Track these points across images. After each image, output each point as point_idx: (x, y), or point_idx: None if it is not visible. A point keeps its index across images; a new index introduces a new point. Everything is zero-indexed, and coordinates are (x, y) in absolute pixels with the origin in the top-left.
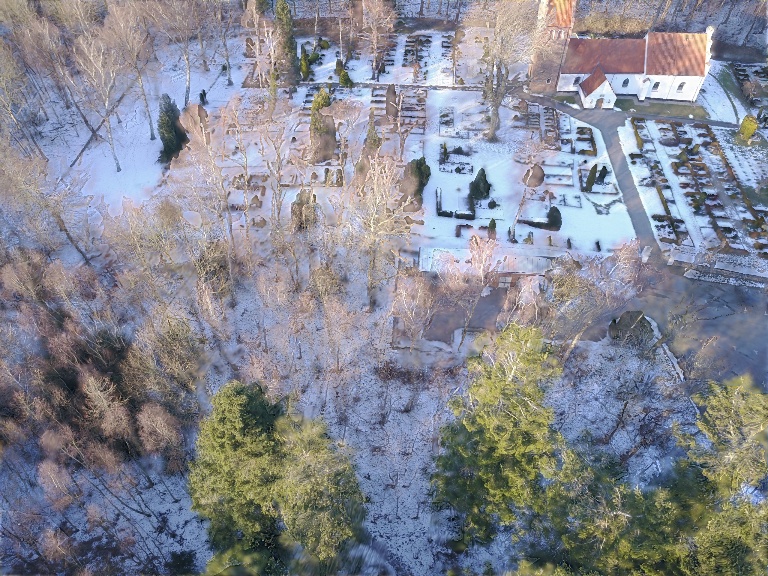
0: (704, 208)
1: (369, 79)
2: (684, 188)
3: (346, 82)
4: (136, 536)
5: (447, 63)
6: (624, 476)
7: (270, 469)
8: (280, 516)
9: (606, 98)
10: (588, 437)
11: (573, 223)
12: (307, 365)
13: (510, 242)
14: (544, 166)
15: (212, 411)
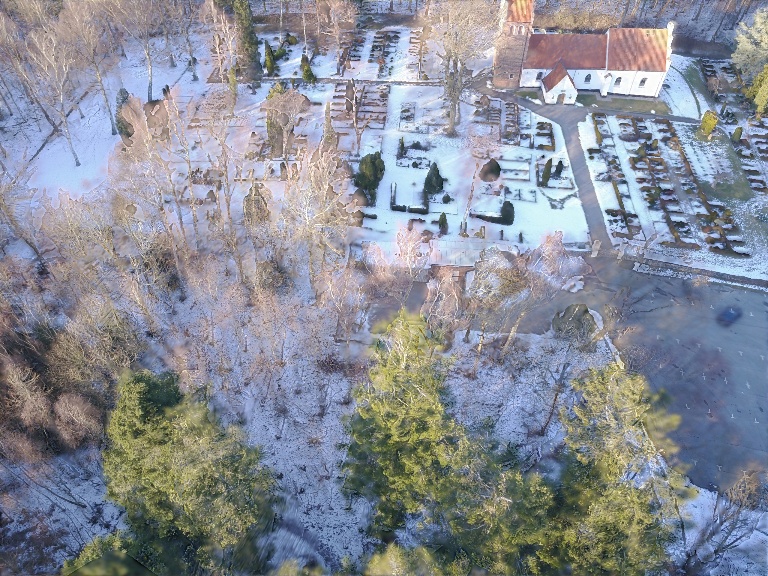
0: (659, 203)
1: (334, 74)
2: (640, 183)
3: (309, 77)
4: (70, 526)
5: (413, 59)
6: (512, 462)
7: (173, 457)
8: (182, 503)
9: (567, 93)
10: (525, 429)
11: (526, 217)
12: (252, 358)
13: (461, 236)
14: (502, 161)
15: (120, 400)
